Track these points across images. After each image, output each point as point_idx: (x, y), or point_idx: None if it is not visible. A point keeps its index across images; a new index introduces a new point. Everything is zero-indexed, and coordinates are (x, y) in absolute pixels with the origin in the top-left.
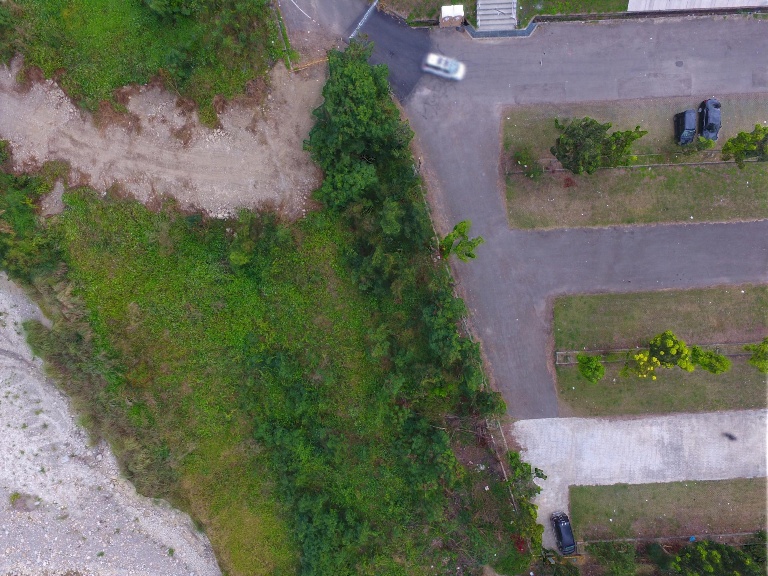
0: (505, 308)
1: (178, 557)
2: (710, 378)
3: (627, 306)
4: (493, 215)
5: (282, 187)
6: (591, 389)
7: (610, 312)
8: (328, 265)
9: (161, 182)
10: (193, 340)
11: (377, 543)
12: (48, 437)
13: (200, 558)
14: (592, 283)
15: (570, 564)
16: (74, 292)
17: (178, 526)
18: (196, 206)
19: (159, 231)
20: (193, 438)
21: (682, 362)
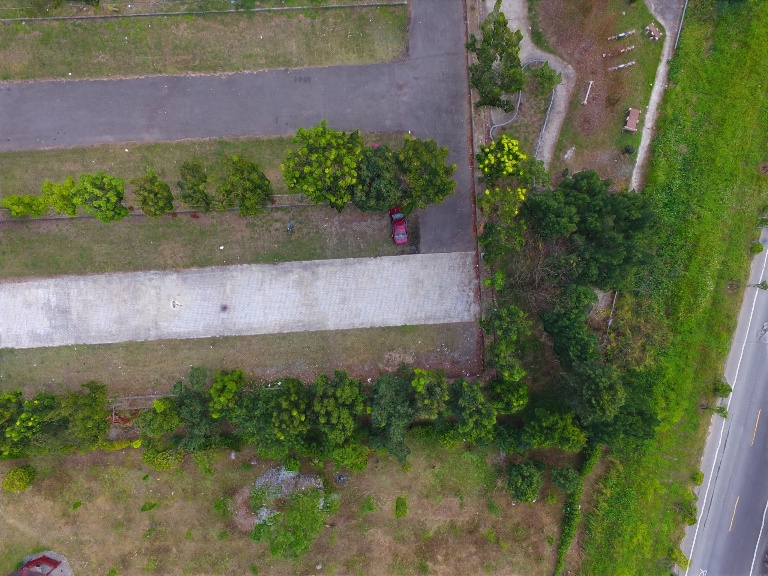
0: None
1: None
2: (97, 239)
3: (7, 165)
4: None
5: None
6: None
7: None
8: None
9: None
10: None
11: None
12: None
13: None
14: None
15: None
16: None
17: None
18: None
19: None
20: None
21: None
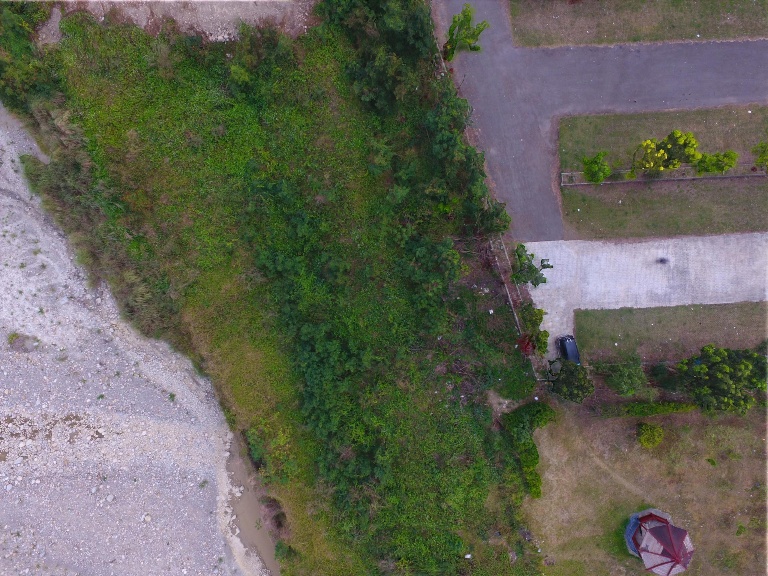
0: (509, 128)
1: (179, 402)
2: (716, 200)
3: (633, 127)
4: (497, 32)
5: (283, 3)
6: (596, 211)
7: (616, 133)
8: (330, 82)
9: (160, 4)
10: (193, 169)
11: (380, 373)
12: (46, 278)
13: (201, 404)
14: (597, 103)
15: (576, 364)
16: (72, 120)
17: (179, 371)
18: (196, 28)
19: (158, 56)
20: (194, 270)
21: (690, 148)
